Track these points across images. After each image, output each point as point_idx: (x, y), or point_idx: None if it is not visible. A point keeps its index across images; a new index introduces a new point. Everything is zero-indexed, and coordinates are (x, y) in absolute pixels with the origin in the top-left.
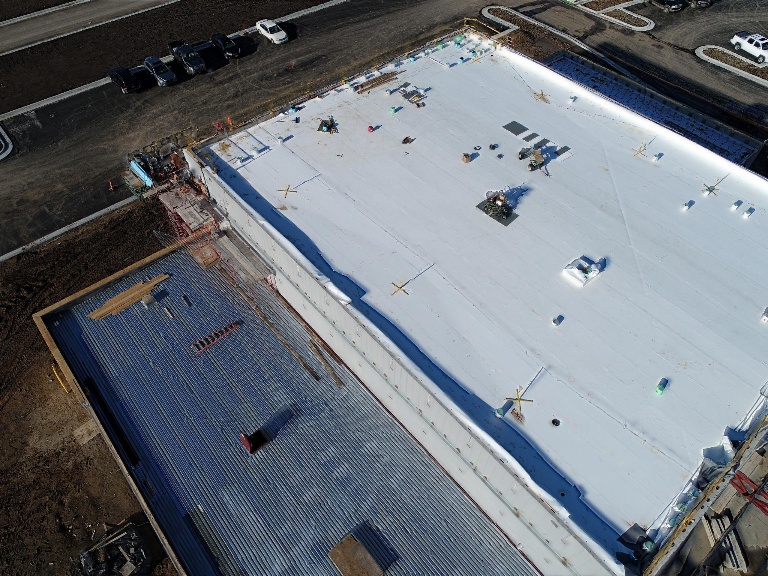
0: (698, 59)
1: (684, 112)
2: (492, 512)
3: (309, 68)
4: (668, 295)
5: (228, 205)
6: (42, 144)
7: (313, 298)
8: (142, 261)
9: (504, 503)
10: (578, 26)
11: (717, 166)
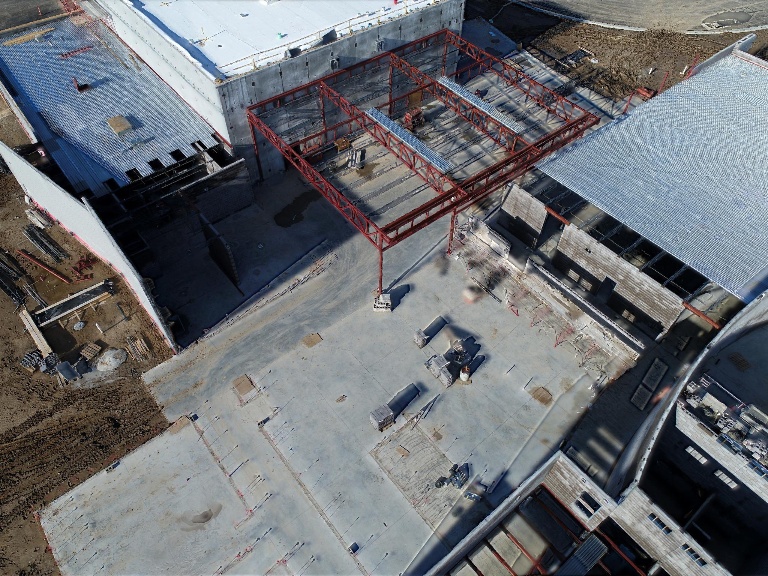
0: None
1: None
2: None
3: None
4: (313, 8)
5: None
6: None
7: (123, 17)
8: None
9: (190, 84)
10: None
11: None
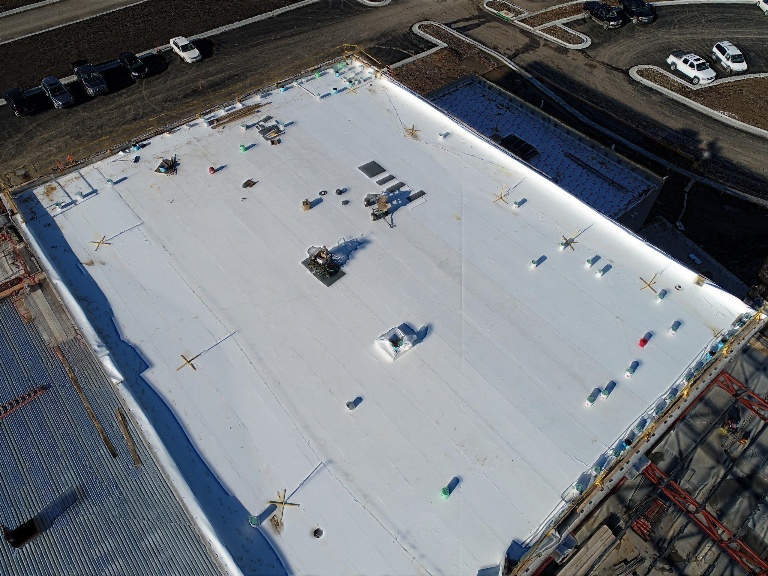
0: (631, 80)
1: (587, 144)
2: None
3: (218, 89)
4: (486, 372)
5: None
6: None
7: None
8: None
9: None
10: (510, 43)
11: (582, 215)
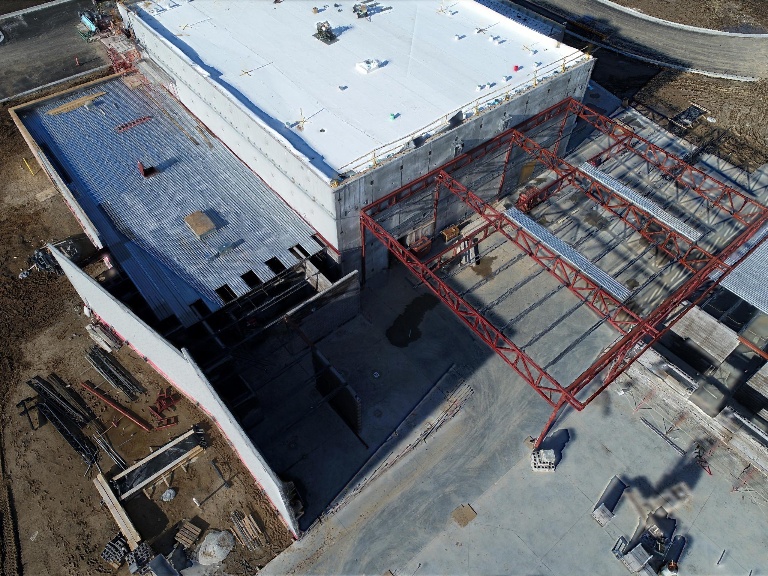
0: None
1: (515, 8)
2: (291, 199)
3: None
4: (421, 78)
5: (145, 37)
6: (27, 36)
7: (193, 86)
8: (87, 83)
9: (288, 178)
10: None
11: (493, 18)
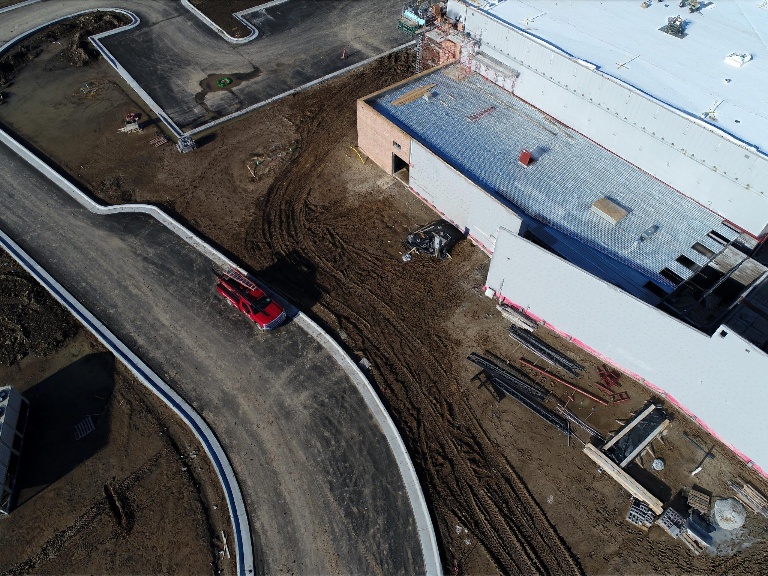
0: None
1: None
2: (689, 188)
3: None
4: None
5: (486, 31)
6: (279, 30)
7: (559, 78)
8: (416, 75)
9: (706, 166)
10: None
11: None
